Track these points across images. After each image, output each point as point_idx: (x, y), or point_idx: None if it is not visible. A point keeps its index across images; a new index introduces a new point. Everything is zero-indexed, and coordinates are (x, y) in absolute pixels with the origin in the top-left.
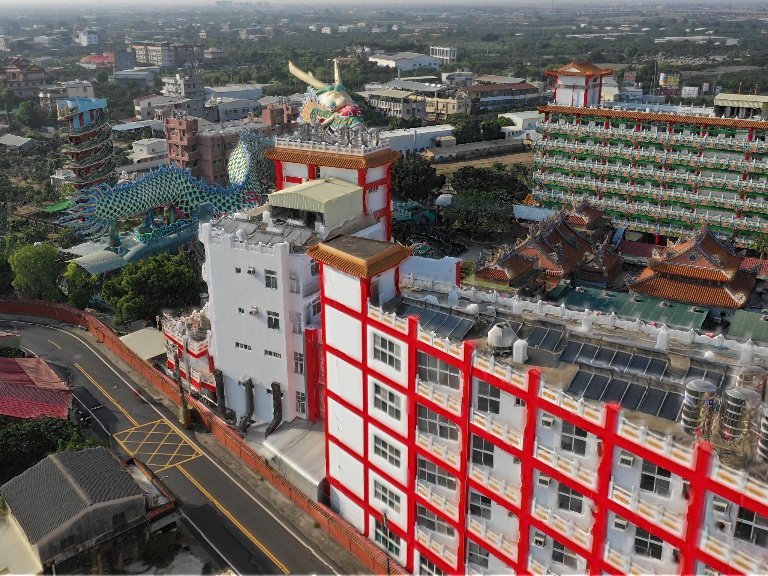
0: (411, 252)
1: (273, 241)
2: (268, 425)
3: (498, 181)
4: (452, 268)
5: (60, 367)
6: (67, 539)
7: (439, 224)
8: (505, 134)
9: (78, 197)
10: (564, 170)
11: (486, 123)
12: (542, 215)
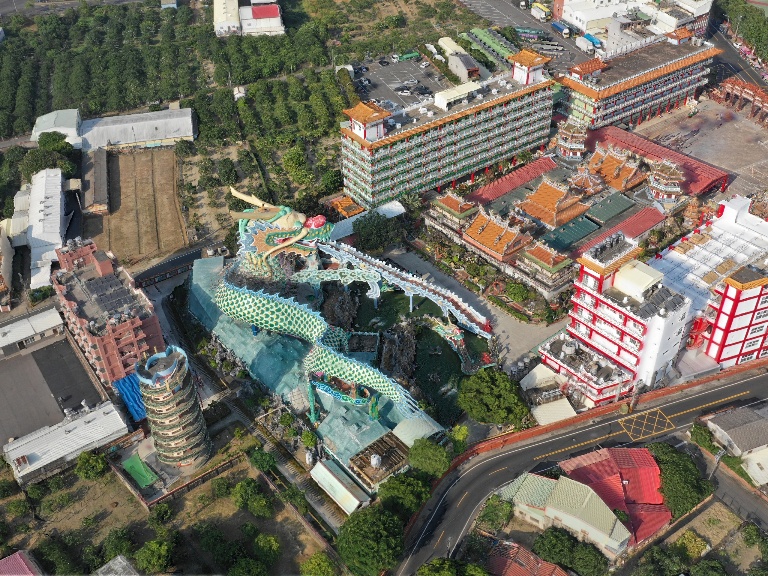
0: None
1: (676, 302)
2: (669, 374)
3: None
4: None
5: (539, 466)
6: None
7: (322, 256)
8: (81, 150)
9: None
10: None
11: (59, 148)
12: (393, 211)
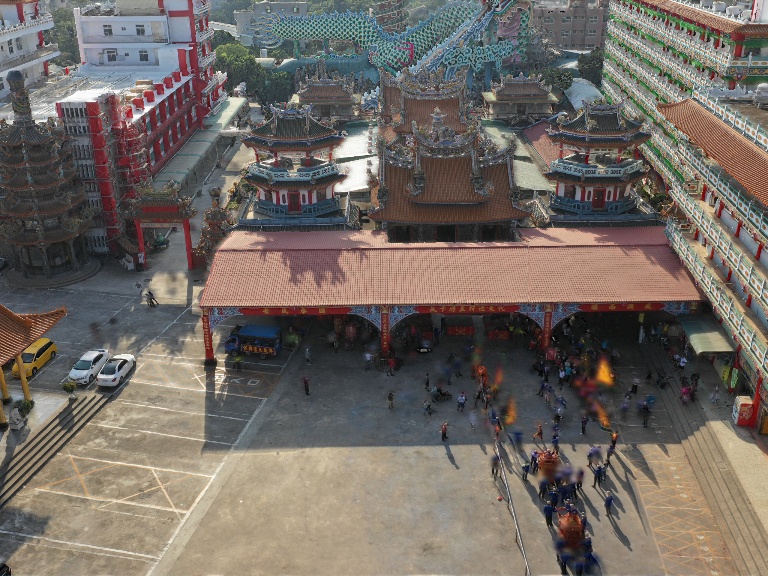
0: (22, 1)
1: None
2: None
3: None
4: (174, 51)
5: None
6: None
7: None
8: None
9: None
10: (610, 57)
11: None
12: None
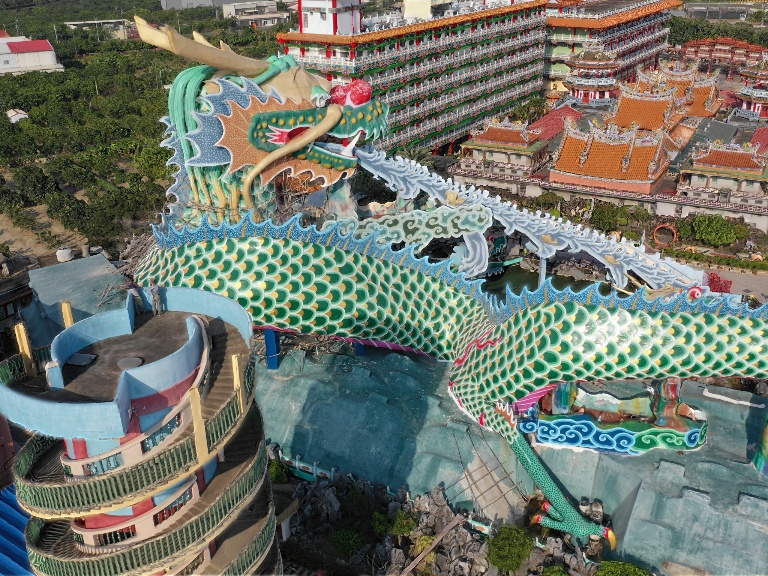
0: None
1: None
2: None
3: None
4: None
5: None
6: None
7: None
8: None
9: None
10: None
11: None
12: None
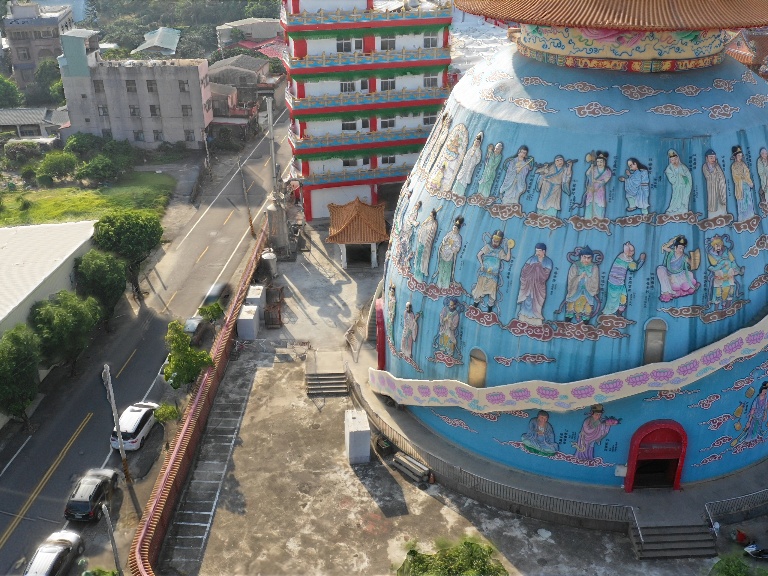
0: None
1: None
2: None
3: None
4: None
5: None
6: (218, 78)
7: None
8: None
9: None
10: None
11: None
12: None
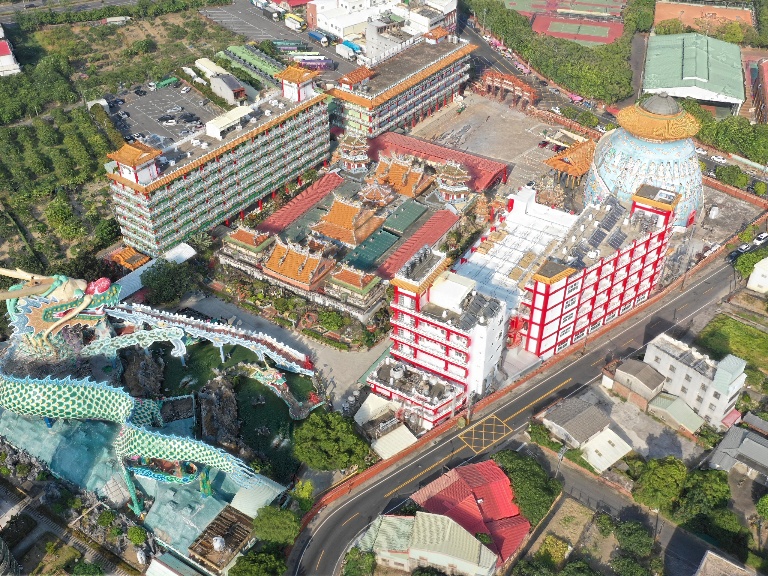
0: None
1: (492, 308)
2: (496, 377)
3: (101, 261)
4: None
5: (391, 504)
6: None
7: None
8: None
9: (245, 465)
10: None
11: None
12: (183, 256)
